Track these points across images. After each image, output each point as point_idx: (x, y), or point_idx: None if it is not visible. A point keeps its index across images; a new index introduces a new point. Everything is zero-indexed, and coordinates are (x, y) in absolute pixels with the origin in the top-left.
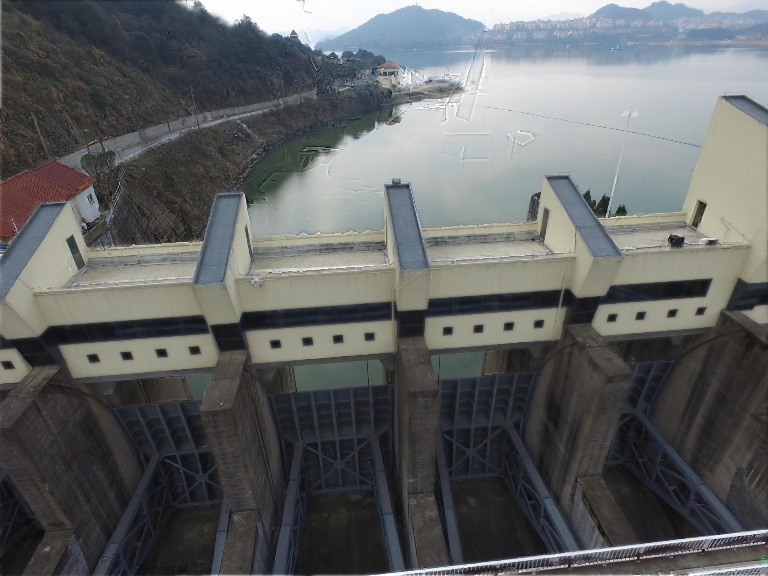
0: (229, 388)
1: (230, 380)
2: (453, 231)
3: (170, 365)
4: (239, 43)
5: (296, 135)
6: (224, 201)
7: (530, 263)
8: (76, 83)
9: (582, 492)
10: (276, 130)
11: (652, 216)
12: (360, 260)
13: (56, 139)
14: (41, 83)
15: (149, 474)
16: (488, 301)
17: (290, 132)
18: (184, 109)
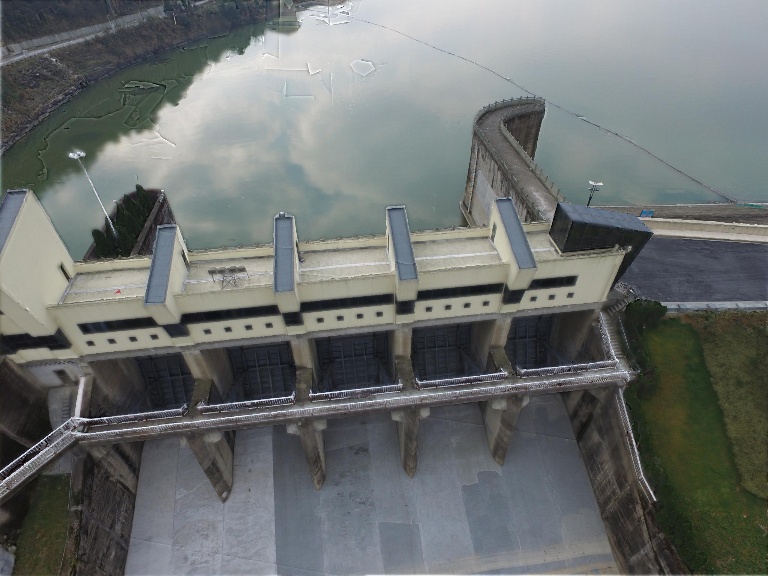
0: None
1: None
2: None
3: None
4: None
5: (133, 63)
6: None
7: None
8: None
9: None
10: (102, 61)
11: None
12: None
13: None
14: None
15: None
16: None
17: (123, 61)
18: None
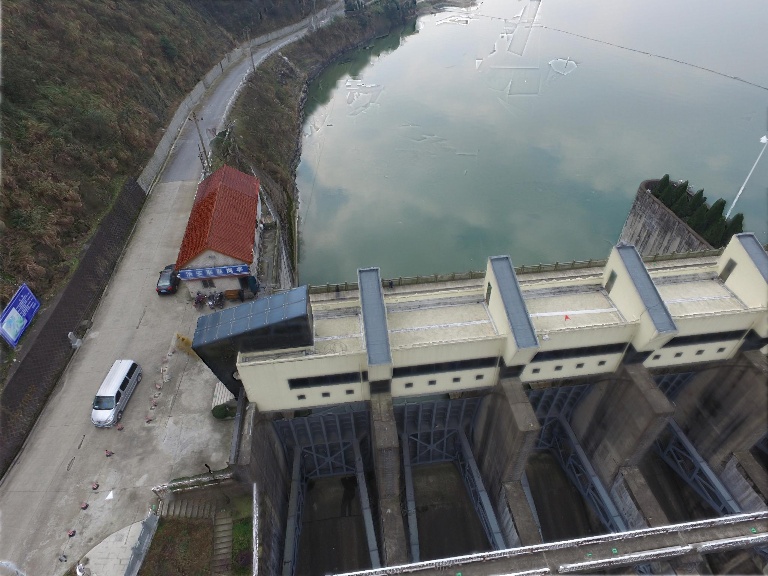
0: (528, 412)
1: (524, 405)
2: (654, 274)
3: (458, 386)
4: None
5: (330, 62)
6: (497, 264)
7: (734, 315)
8: (148, 35)
9: (738, 462)
10: (313, 59)
11: None
12: (591, 304)
13: (155, 108)
14: (124, 43)
15: (407, 449)
16: (692, 337)
17: (325, 60)
18: (226, 42)
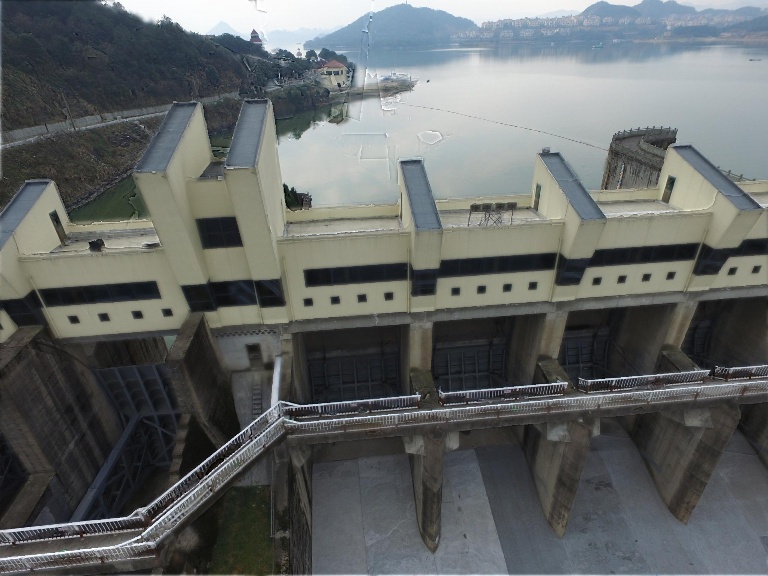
0: None
1: None
2: None
3: None
4: (152, 44)
5: None
6: None
7: None
8: None
9: None
10: None
11: None
12: None
13: None
14: None
15: None
16: None
17: None
18: (77, 110)
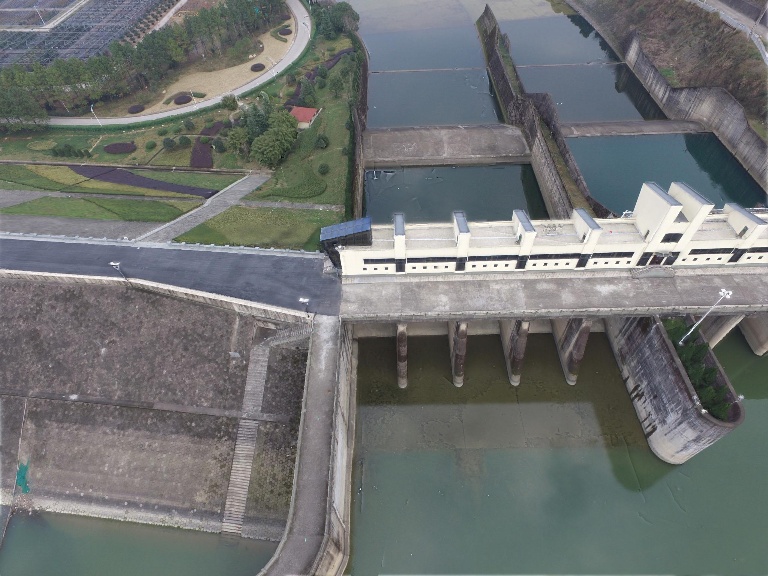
0: None
1: None
2: None
3: None
4: None
5: None
6: None
7: None
8: None
9: None
10: None
11: (704, 239)
12: None
13: None
14: None
15: None
16: None
17: None
18: None
